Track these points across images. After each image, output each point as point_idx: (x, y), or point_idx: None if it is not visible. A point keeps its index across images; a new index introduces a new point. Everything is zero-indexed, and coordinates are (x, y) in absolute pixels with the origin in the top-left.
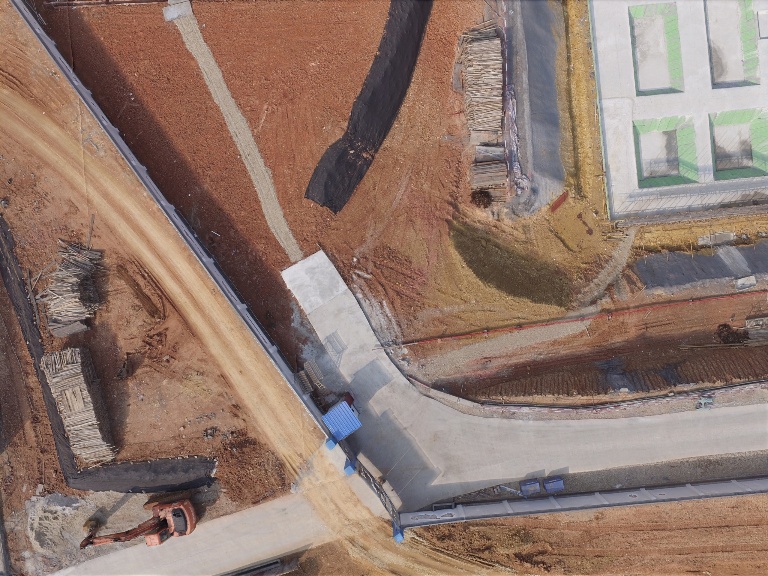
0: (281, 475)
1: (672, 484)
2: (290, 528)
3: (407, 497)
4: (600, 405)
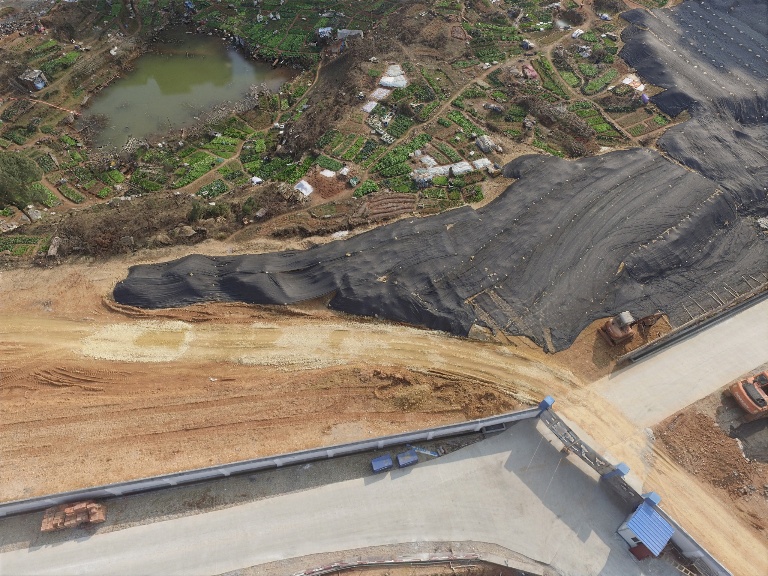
0: (670, 448)
1: (246, 474)
2: (636, 392)
3: (533, 435)
4: (331, 572)
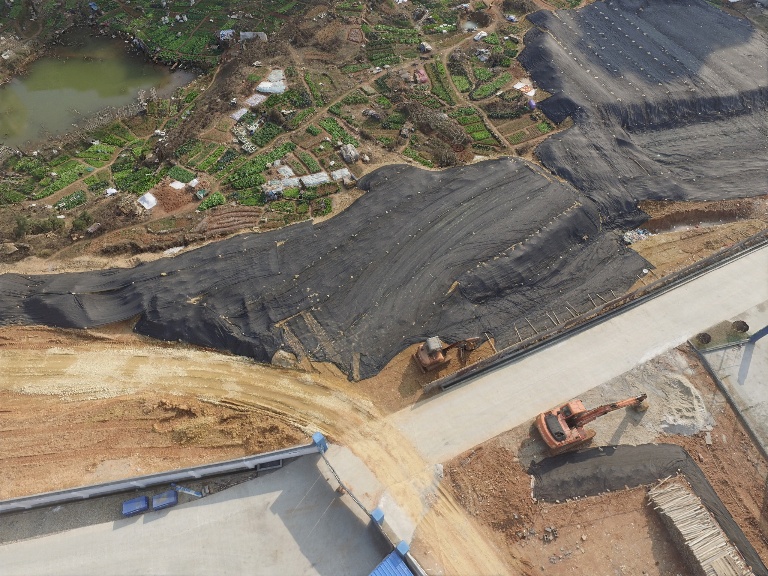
0: (457, 486)
1: None
2: (437, 424)
3: (311, 472)
4: None
